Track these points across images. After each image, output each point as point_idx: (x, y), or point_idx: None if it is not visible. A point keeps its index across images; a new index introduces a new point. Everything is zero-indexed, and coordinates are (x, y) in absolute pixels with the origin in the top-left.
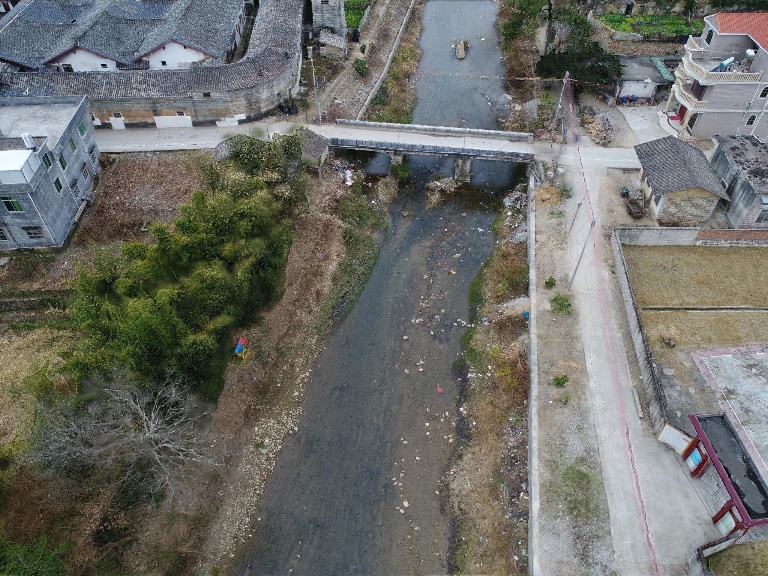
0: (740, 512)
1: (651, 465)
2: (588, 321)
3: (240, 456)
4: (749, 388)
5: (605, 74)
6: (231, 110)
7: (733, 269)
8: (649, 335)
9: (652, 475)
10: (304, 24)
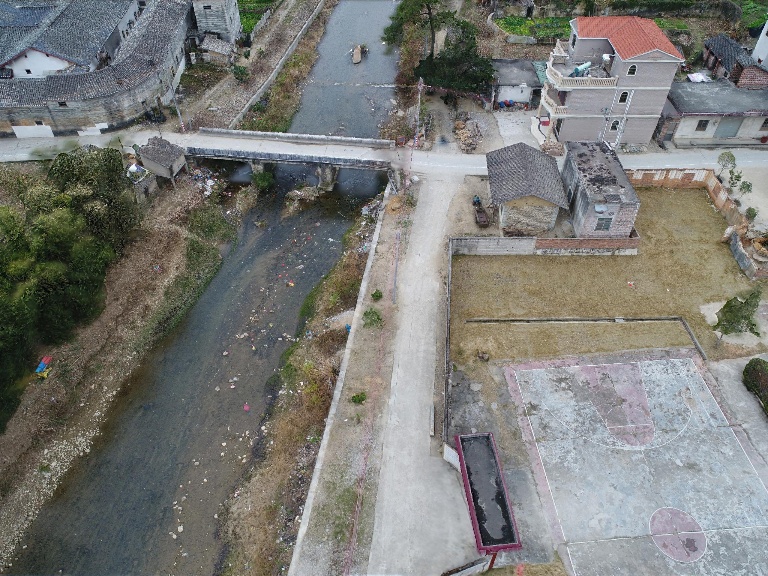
0: (476, 538)
1: (429, 486)
2: (405, 335)
3: None
4: (553, 403)
5: (476, 79)
6: (91, 119)
7: (569, 279)
8: (465, 349)
9: (428, 496)
10: (190, 30)
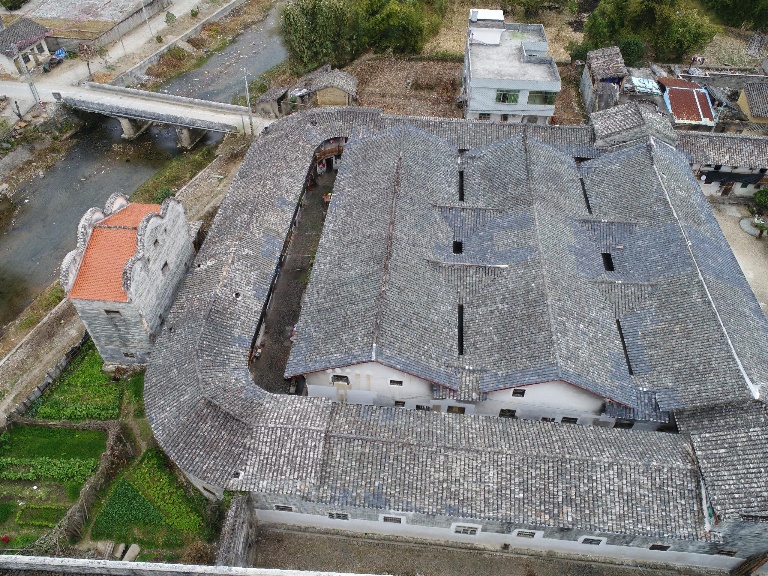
0: None
1: None
2: None
3: None
4: None
5: None
6: None
7: None
8: None
9: None
10: None
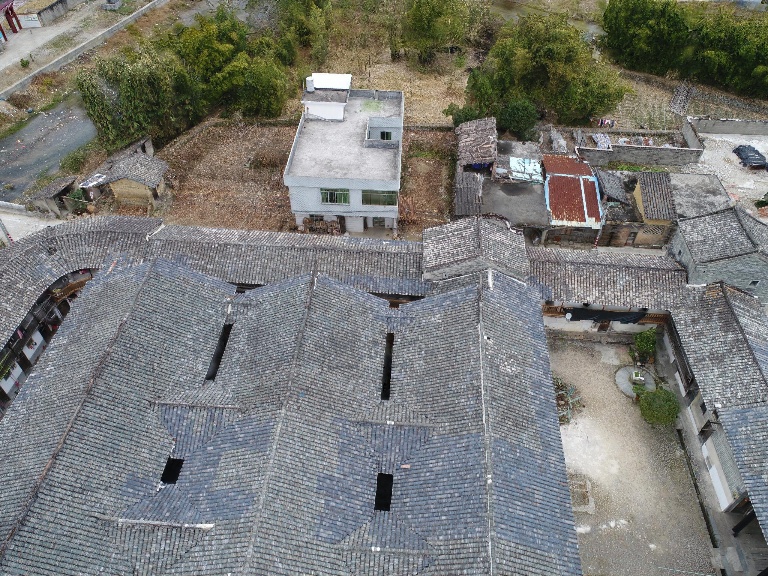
0: None
1: None
2: None
3: None
4: None
5: None
6: None
7: None
8: None
9: None
10: None
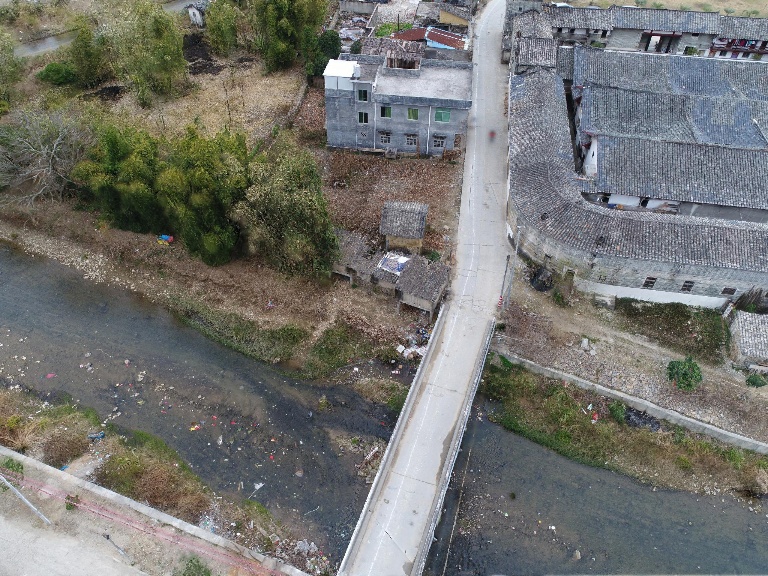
0: None
1: None
2: None
3: (6, 195)
4: None
5: None
6: None
7: None
8: None
9: None
10: None
